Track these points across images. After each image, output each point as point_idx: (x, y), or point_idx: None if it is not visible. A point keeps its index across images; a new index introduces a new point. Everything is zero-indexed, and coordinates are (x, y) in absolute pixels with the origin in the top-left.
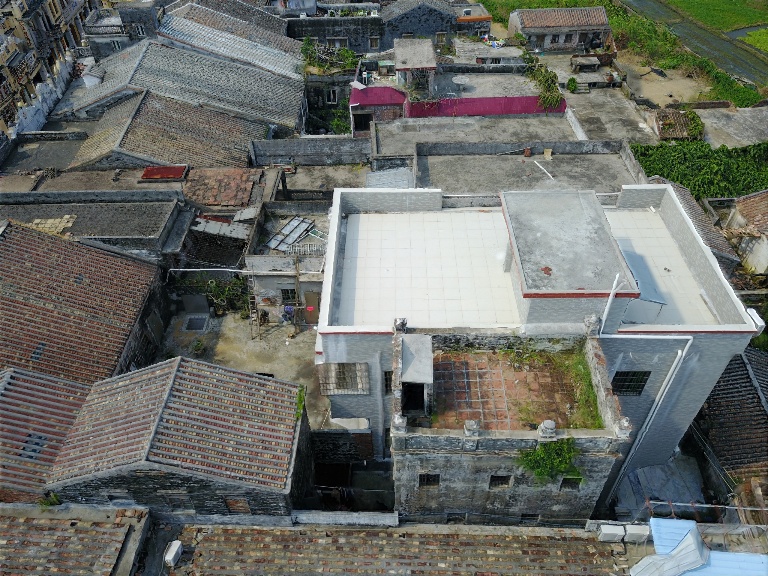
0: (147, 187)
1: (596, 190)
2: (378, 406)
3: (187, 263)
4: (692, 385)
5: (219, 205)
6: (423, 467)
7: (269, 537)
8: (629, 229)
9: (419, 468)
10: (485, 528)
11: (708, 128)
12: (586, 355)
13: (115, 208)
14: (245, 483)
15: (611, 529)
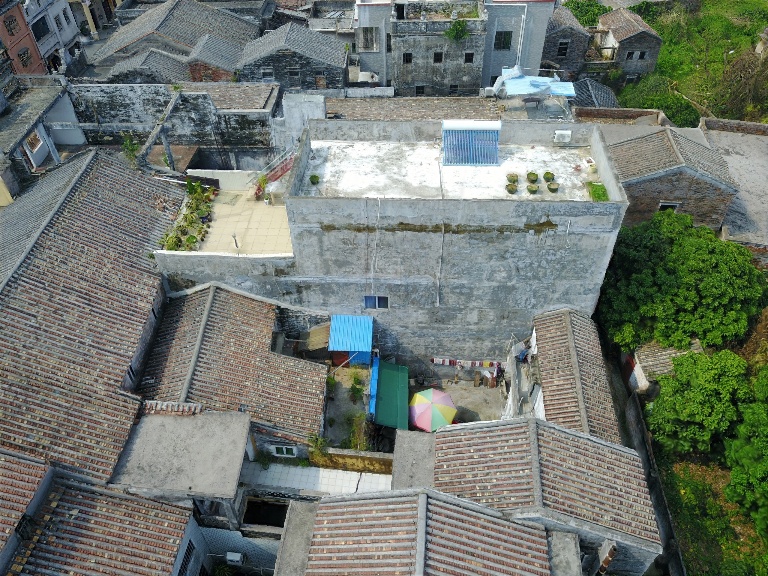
0: None
1: None
2: (383, 61)
3: (275, 26)
4: (533, 42)
5: (288, 6)
6: (404, 47)
7: (334, 100)
8: None
9: (402, 48)
10: (434, 97)
11: (603, 0)
12: (477, 10)
13: (230, 3)
14: (326, 60)
15: (489, 88)
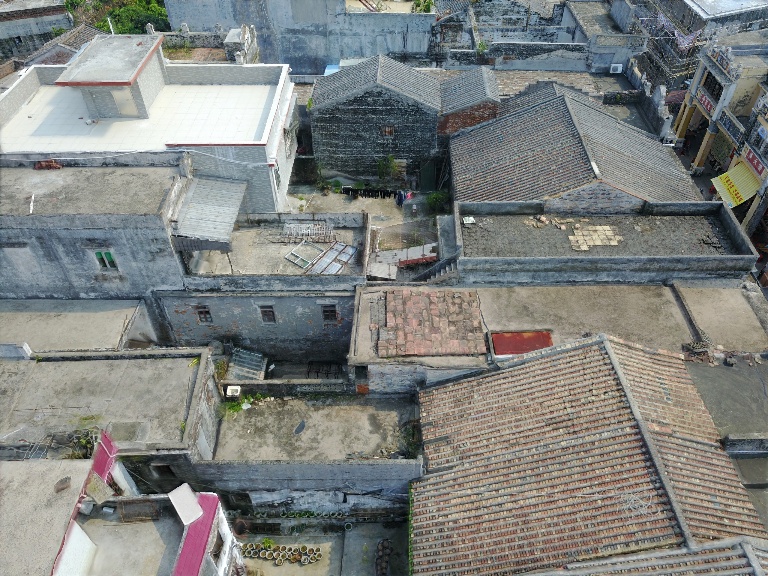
0: (534, 323)
1: (4, 183)
2: None
3: None
4: None
5: None
6: None
7: None
8: (21, 143)
9: None
10: None
11: None
12: None
13: None
14: None
15: None
